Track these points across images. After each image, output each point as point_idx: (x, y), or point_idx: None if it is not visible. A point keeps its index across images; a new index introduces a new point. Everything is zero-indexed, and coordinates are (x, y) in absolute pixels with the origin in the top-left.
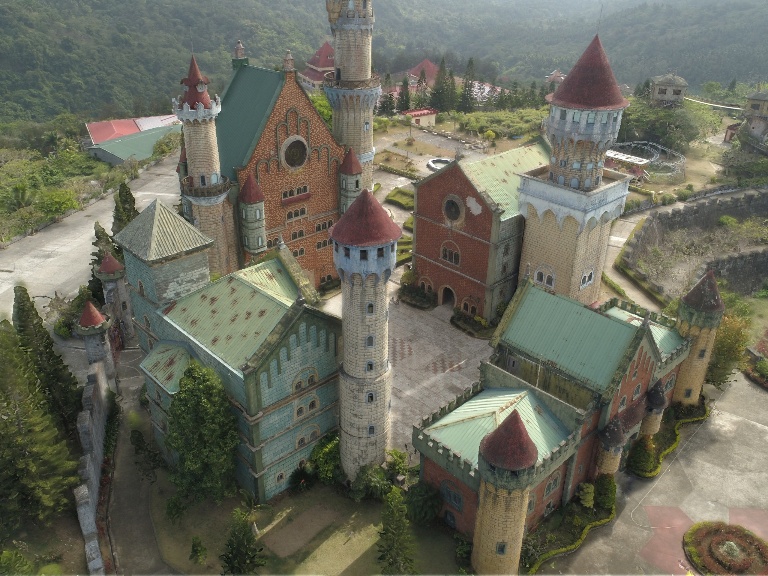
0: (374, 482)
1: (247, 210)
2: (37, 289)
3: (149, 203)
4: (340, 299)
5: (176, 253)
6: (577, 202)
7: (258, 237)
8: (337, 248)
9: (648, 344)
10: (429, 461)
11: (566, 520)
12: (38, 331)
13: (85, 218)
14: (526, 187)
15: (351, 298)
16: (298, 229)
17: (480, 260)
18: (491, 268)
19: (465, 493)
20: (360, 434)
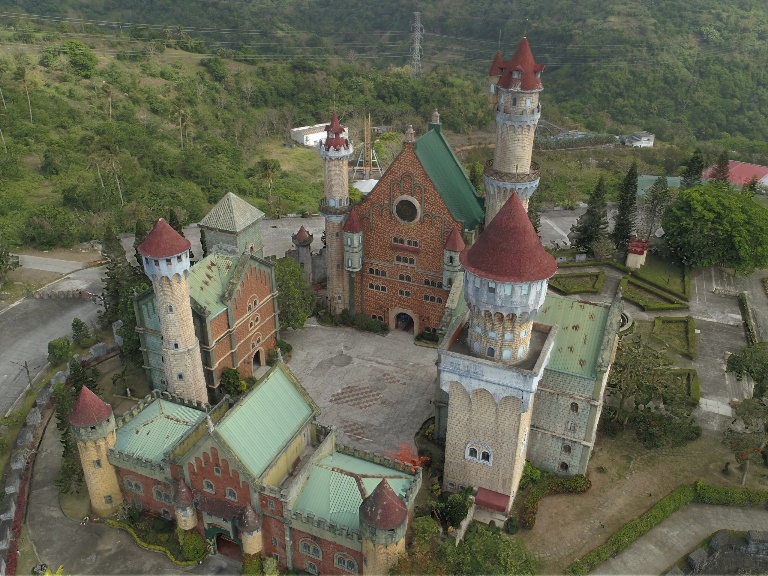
0: None
1: None
2: None
3: None
4: (424, 351)
5: (214, 227)
6: None
7: (349, 258)
8: None
9: None
10: None
11: (168, 534)
12: None
13: None
14: None
15: None
16: (406, 273)
17: None
18: None
19: None
20: None
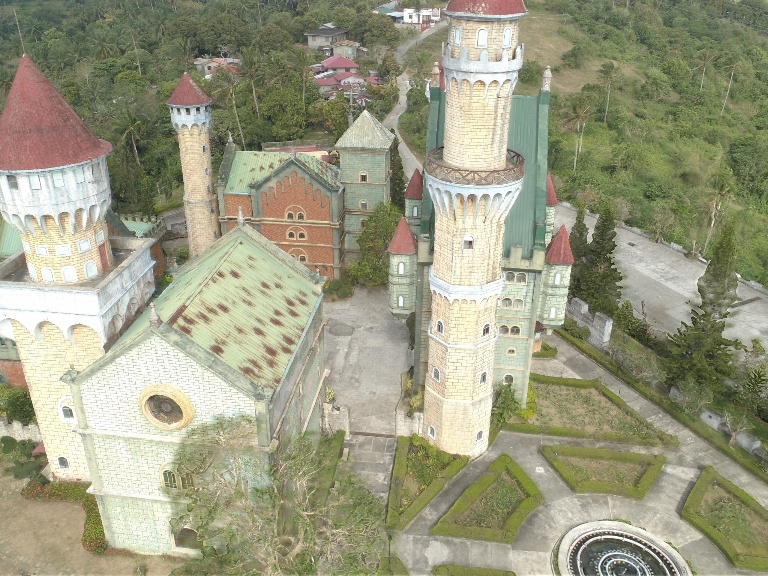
0: None
1: None
2: (662, 300)
3: None
4: (392, 381)
5: None
6: None
7: None
8: None
9: None
10: None
11: None
12: None
13: None
14: None
15: None
16: None
17: None
18: None
19: None
20: None
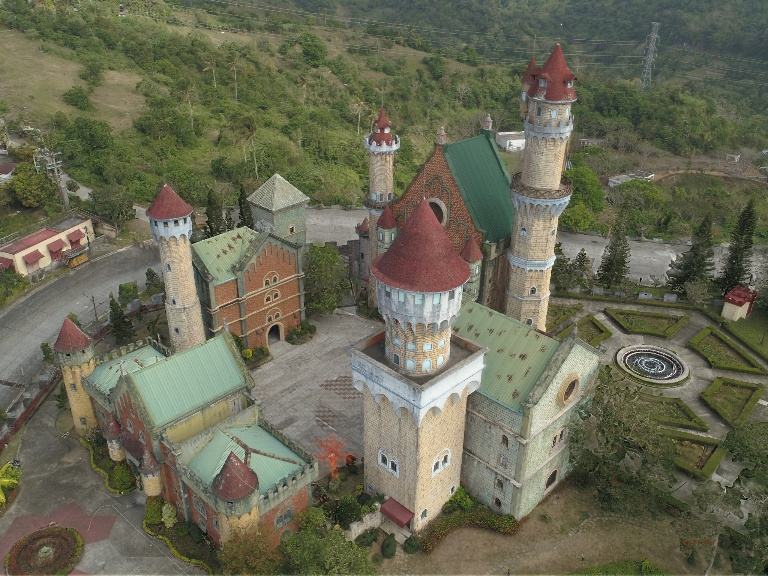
0: None
1: None
2: None
3: (647, 261)
4: None
5: None
6: None
7: None
8: None
9: None
10: None
11: None
12: None
13: (589, 241)
14: None
15: None
16: None
17: None
18: None
19: None
20: None
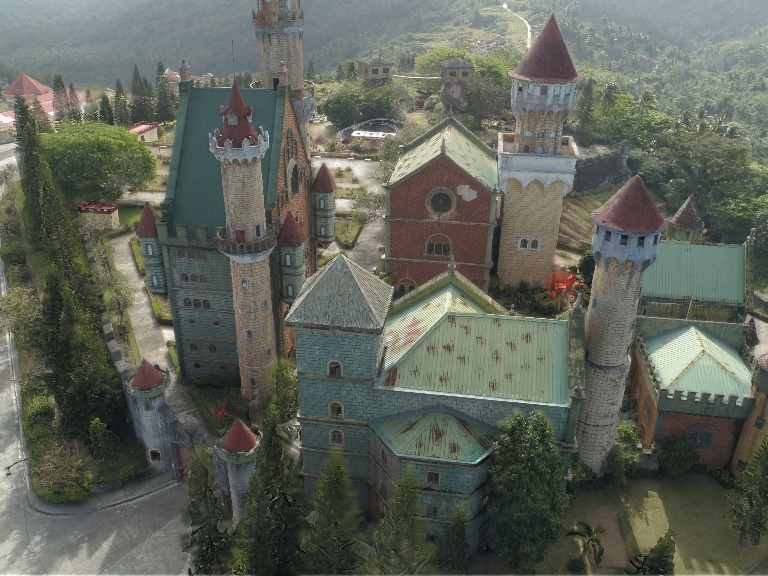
0: (630, 460)
1: (295, 254)
2: None
3: None
4: None
5: (387, 311)
6: (566, 166)
7: (303, 282)
8: (621, 241)
9: None
10: (670, 417)
11: None
12: None
13: None
14: (509, 164)
15: (627, 288)
16: None
17: (477, 243)
18: None
19: (718, 427)
20: (613, 421)
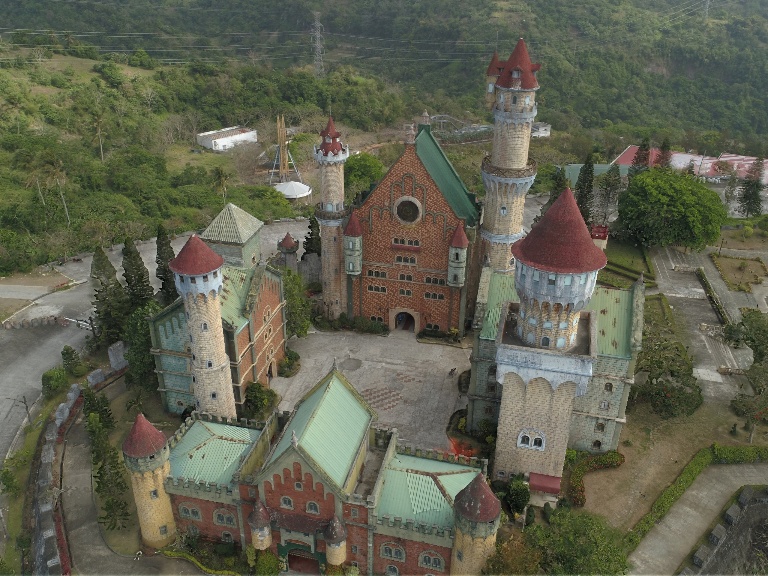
0: None
1: (344, 239)
2: None
3: None
4: (429, 347)
5: (217, 240)
6: None
7: (350, 262)
8: None
9: (310, 467)
10: None
11: None
12: (168, 254)
13: None
14: None
15: None
16: (407, 273)
17: None
18: (471, 378)
19: None
20: None
